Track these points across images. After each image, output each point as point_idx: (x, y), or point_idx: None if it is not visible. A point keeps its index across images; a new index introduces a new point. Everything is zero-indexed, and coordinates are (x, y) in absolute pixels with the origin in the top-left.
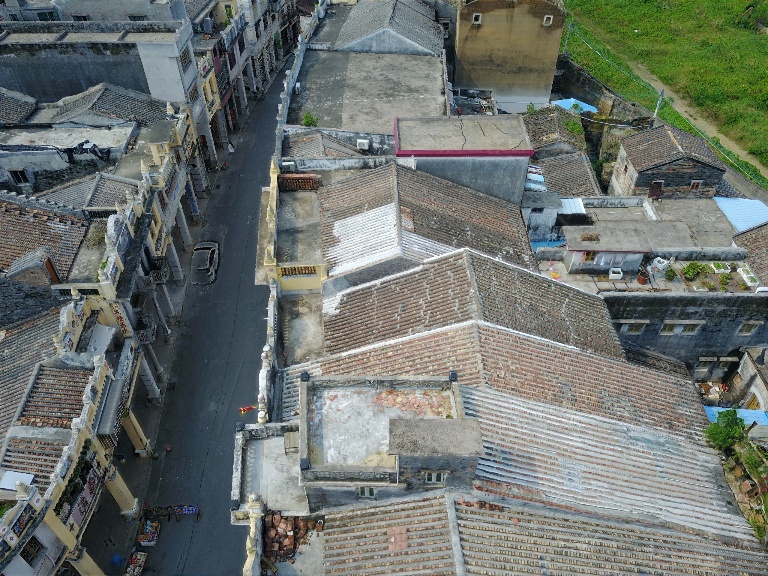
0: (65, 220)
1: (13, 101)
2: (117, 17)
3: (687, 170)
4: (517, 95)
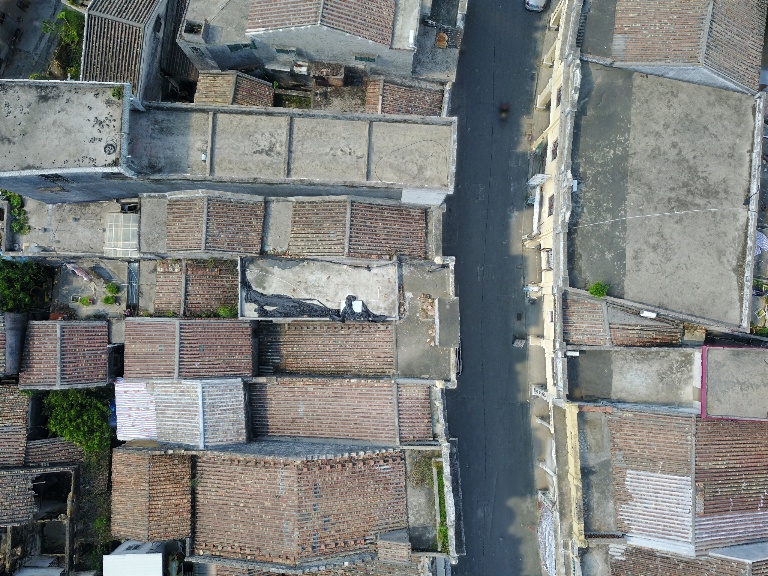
0: (386, 457)
1: (242, 207)
2: (337, 52)
3: None
4: None
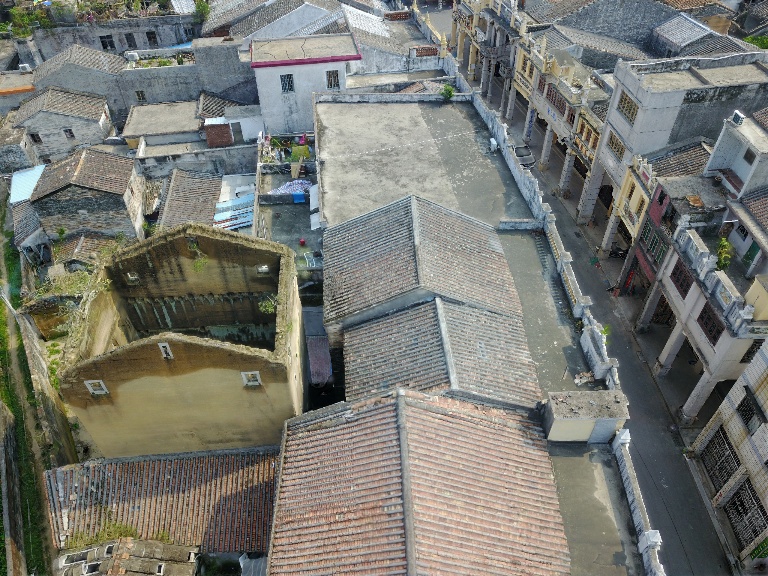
0: None
1: None
2: None
3: None
4: None
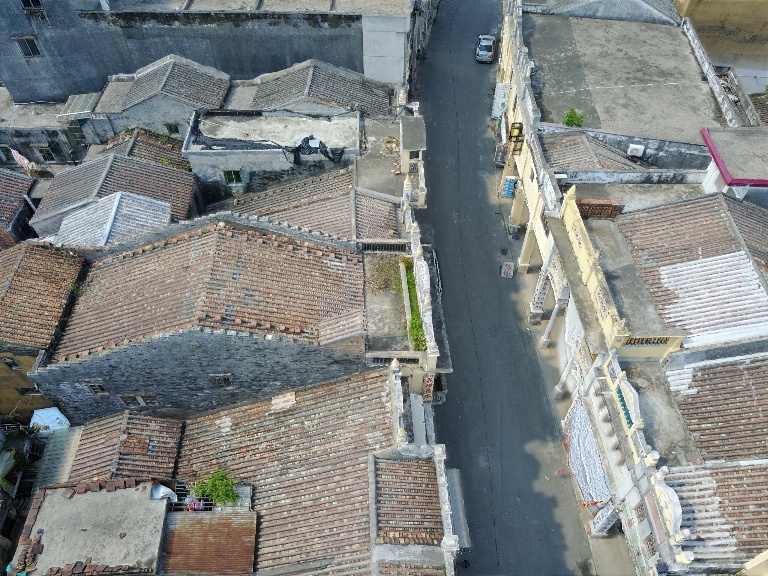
0: (338, 254)
1: (207, 78)
2: None
3: None
4: (741, 67)
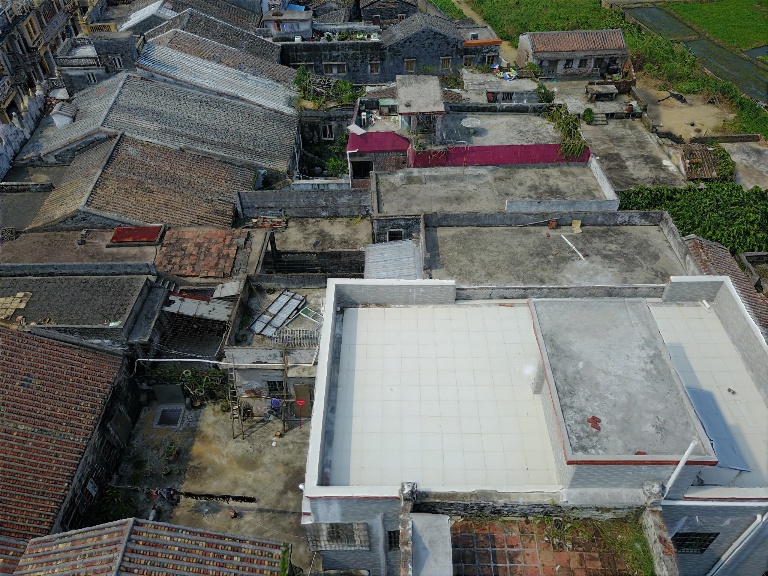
0: None
1: None
2: None
3: (392, 6)
4: None
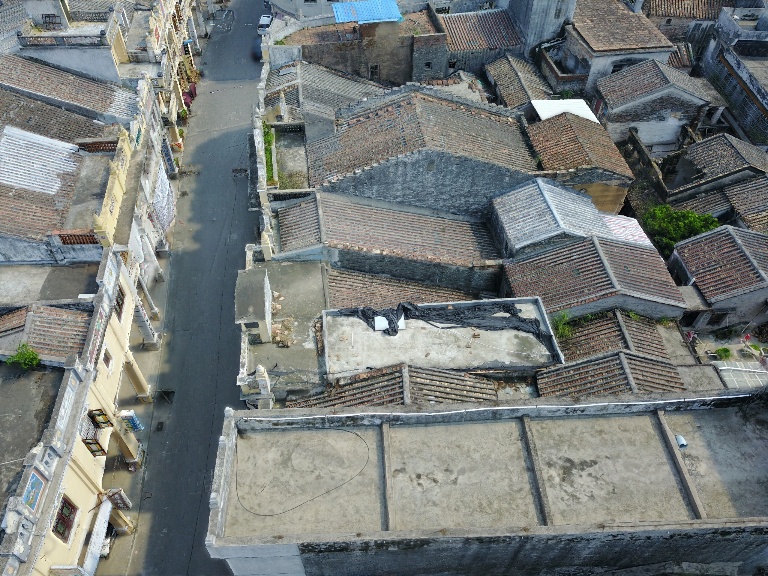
0: None
1: None
2: None
3: None
4: None
